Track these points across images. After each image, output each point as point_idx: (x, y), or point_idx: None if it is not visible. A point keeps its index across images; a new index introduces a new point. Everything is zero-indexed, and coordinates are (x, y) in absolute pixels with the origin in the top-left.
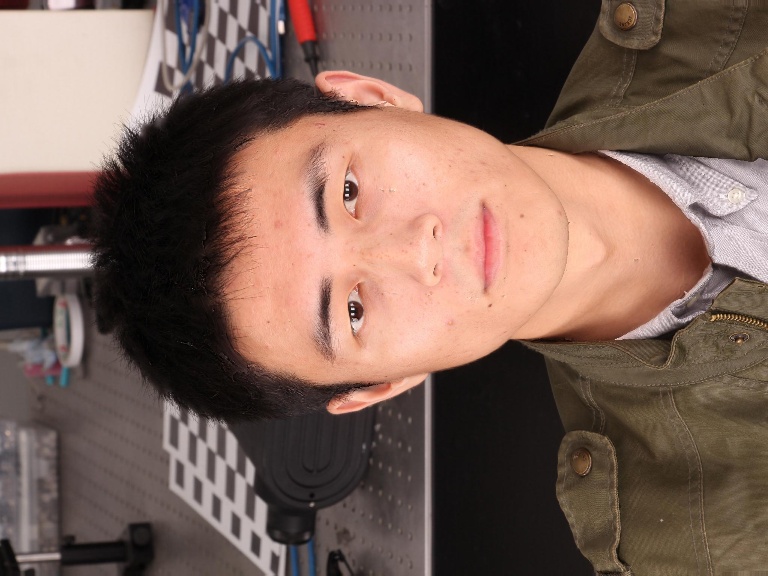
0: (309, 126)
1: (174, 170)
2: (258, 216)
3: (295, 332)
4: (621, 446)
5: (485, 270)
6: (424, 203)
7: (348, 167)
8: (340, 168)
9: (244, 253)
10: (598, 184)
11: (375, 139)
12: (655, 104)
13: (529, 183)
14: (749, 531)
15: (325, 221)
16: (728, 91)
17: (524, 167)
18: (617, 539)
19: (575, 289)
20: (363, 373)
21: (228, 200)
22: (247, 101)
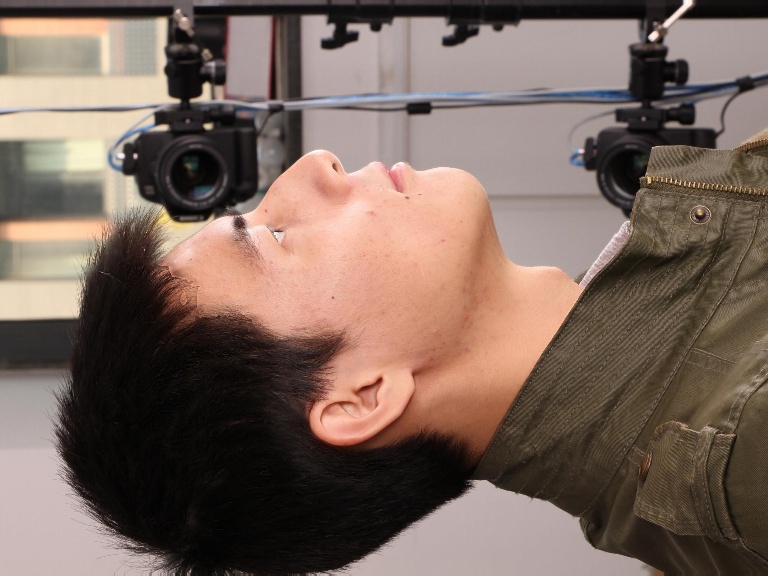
0: None
1: None
2: None
3: (216, 252)
4: None
5: (391, 177)
6: None
7: None
8: None
9: None
10: None
11: None
12: None
13: None
14: None
15: None
16: None
17: None
18: None
19: (542, 296)
20: (305, 292)
21: None
22: None
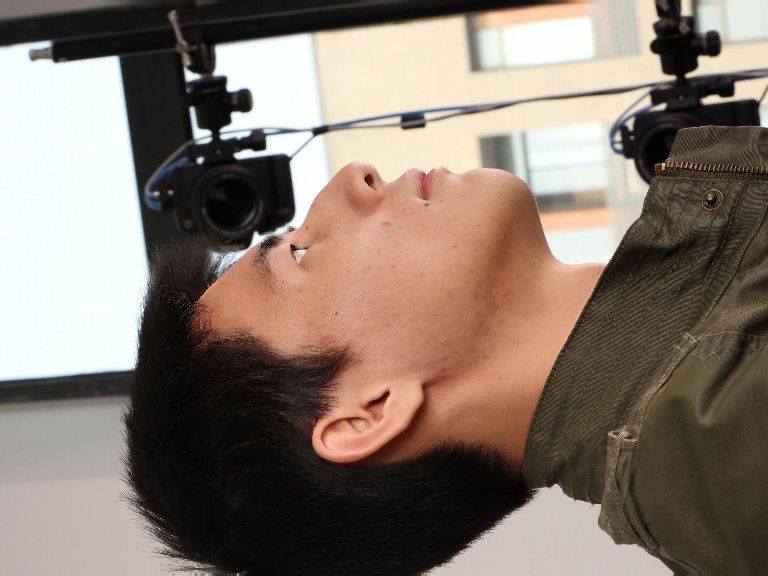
0: None
1: None
2: None
3: (241, 274)
4: (662, 443)
5: None
6: None
7: None
8: None
9: None
10: None
11: None
12: None
13: None
14: (733, 297)
15: None
16: None
17: None
18: None
19: (575, 296)
20: (311, 309)
21: None
22: None
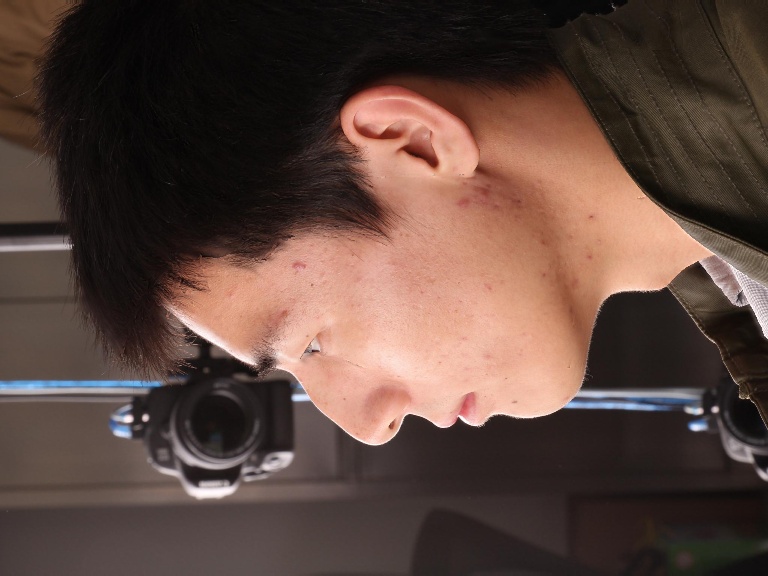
0: (284, 266)
1: (108, 249)
2: (196, 328)
3: None
4: None
5: None
6: None
7: None
8: (298, 349)
9: None
10: None
11: (354, 327)
12: None
13: (541, 371)
14: None
15: (272, 364)
16: None
17: (546, 344)
18: None
19: None
20: None
21: (166, 300)
22: (206, 244)
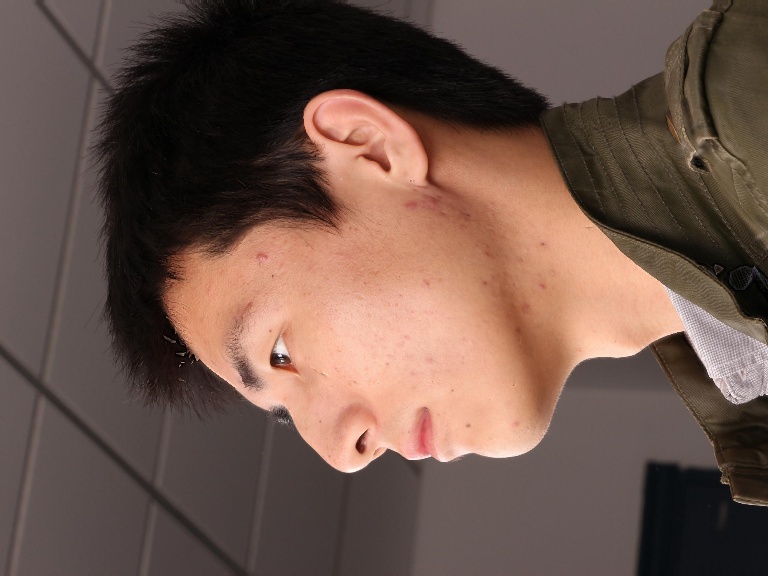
0: (250, 257)
1: None
2: None
3: None
4: None
5: None
6: (358, 395)
7: (277, 339)
8: (264, 346)
9: None
10: (643, 271)
11: (306, 317)
12: (685, 262)
13: (484, 385)
14: None
15: (257, 382)
16: None
17: (487, 354)
18: None
19: None
20: None
21: None
22: (178, 224)
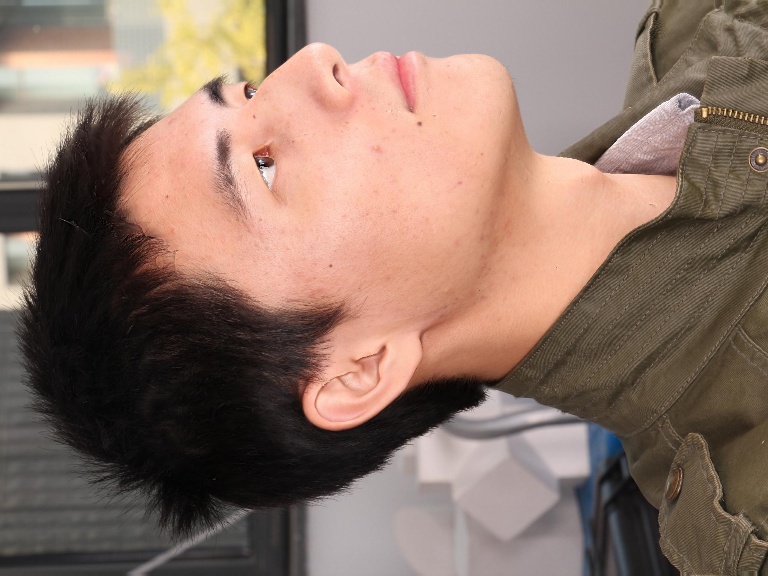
0: None
1: None
2: (153, 129)
3: (197, 194)
4: None
5: (402, 83)
6: None
7: None
8: None
9: (139, 157)
10: None
11: None
12: None
13: None
14: None
15: None
16: (707, 35)
17: None
18: (718, 494)
19: (573, 217)
20: (299, 258)
21: None
22: None
